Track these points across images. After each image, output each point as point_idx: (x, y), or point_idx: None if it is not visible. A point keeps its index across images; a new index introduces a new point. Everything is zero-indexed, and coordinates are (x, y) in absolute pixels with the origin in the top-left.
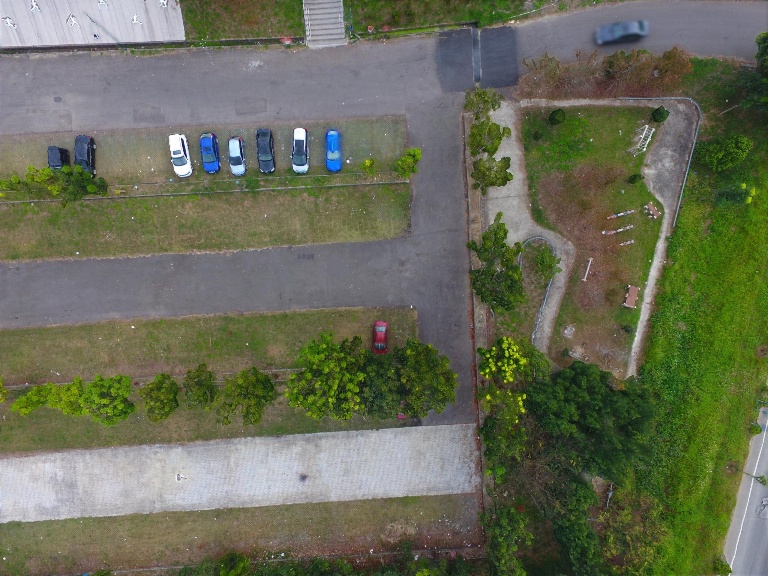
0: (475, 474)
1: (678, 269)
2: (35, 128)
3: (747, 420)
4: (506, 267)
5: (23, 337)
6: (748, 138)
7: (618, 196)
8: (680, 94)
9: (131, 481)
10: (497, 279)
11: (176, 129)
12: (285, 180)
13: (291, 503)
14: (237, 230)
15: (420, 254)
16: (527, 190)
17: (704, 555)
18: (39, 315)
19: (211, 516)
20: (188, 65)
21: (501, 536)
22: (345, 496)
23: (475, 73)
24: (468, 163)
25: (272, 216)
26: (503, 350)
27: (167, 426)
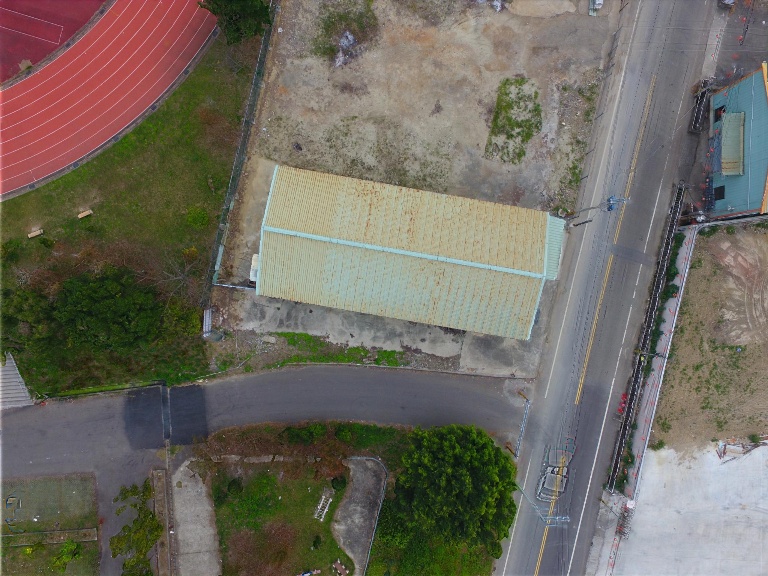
0: None
1: None
2: None
3: None
4: None
5: None
6: None
7: (308, 553)
8: (368, 452)
9: None
10: None
11: None
12: None
13: None
14: None
15: None
16: (218, 546)
17: None
18: None
19: None
20: None
21: None
22: None
23: (165, 430)
24: None
25: None
26: None
27: None
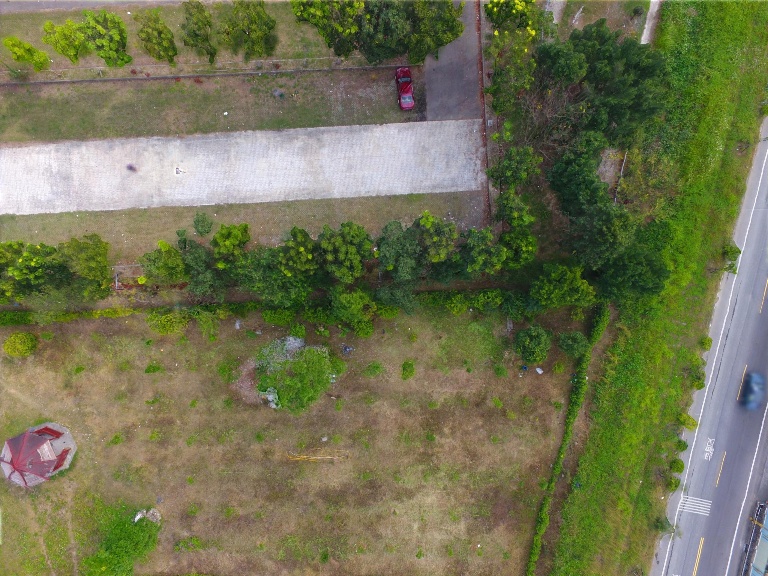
0: (481, 171)
1: None
2: None
3: (758, 100)
4: None
5: (15, 22)
6: None
7: None
8: None
9: (128, 174)
10: None
11: None
12: None
13: (293, 199)
14: None
15: None
16: None
17: (713, 239)
18: None
19: (211, 212)
20: None
21: (509, 170)
22: (348, 193)
23: None
24: None
25: None
26: None
27: (165, 118)
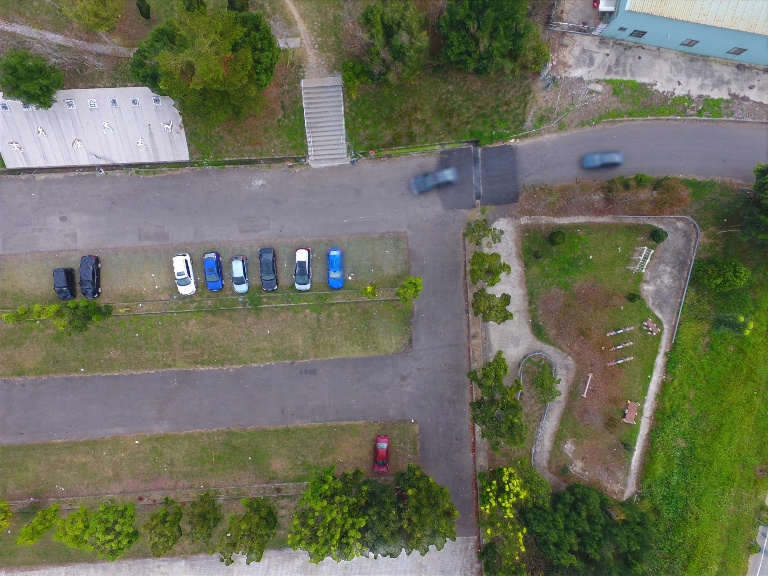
0: None
1: (677, 385)
2: (41, 247)
3: (746, 539)
4: (506, 406)
5: (28, 452)
6: (746, 258)
7: (617, 312)
8: None
9: None
10: (497, 417)
11: (180, 247)
12: (288, 297)
13: None
14: (240, 346)
15: (421, 369)
16: (527, 306)
17: None
18: (44, 431)
19: None
20: (192, 184)
21: None
22: None
23: (476, 191)
24: (469, 279)
25: (275, 332)
26: (503, 483)
27: None
